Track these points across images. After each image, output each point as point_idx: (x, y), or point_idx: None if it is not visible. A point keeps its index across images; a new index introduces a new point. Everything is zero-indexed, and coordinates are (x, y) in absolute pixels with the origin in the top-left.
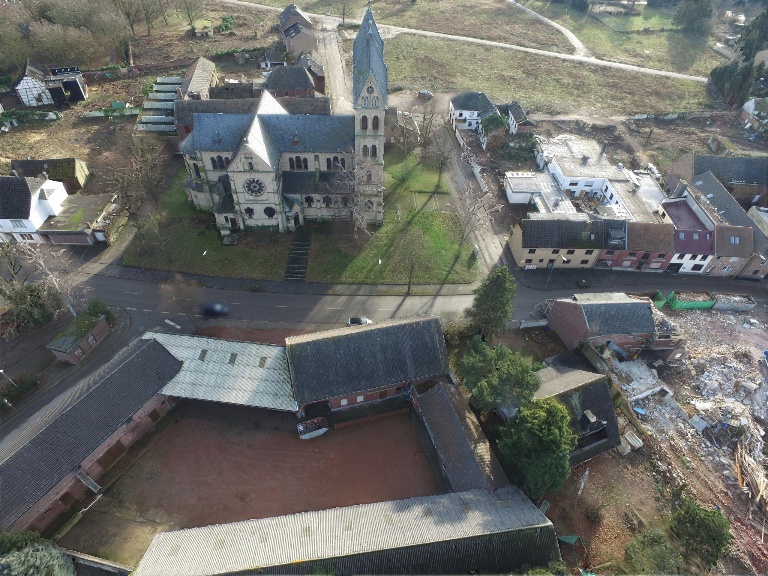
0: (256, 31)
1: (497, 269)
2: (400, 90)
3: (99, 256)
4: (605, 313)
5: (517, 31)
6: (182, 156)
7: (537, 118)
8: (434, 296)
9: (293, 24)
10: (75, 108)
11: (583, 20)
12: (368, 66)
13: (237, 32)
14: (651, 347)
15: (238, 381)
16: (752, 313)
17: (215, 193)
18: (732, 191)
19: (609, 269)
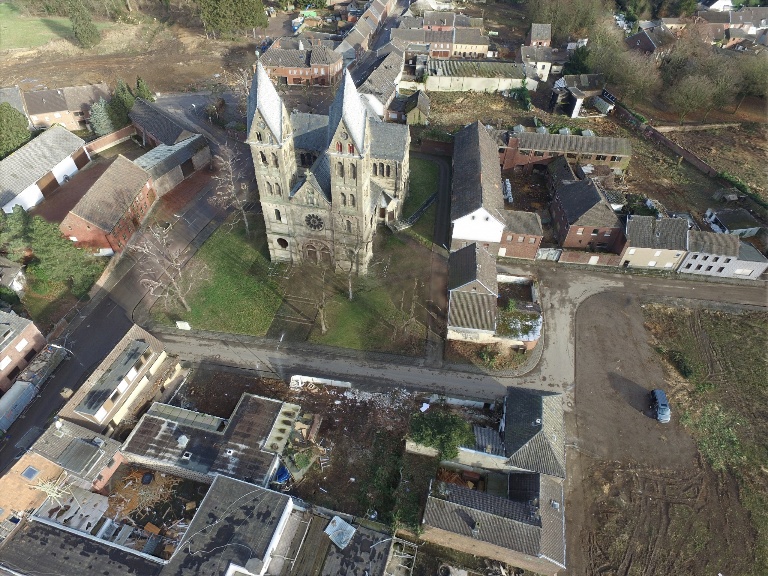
0: None
1: None
2: (681, 371)
3: None
4: None
5: None
6: (448, 161)
7: None
8: (157, 279)
9: None
10: (553, 115)
11: None
12: None
13: None
14: None
15: (142, 161)
16: None
17: None
18: None
19: None
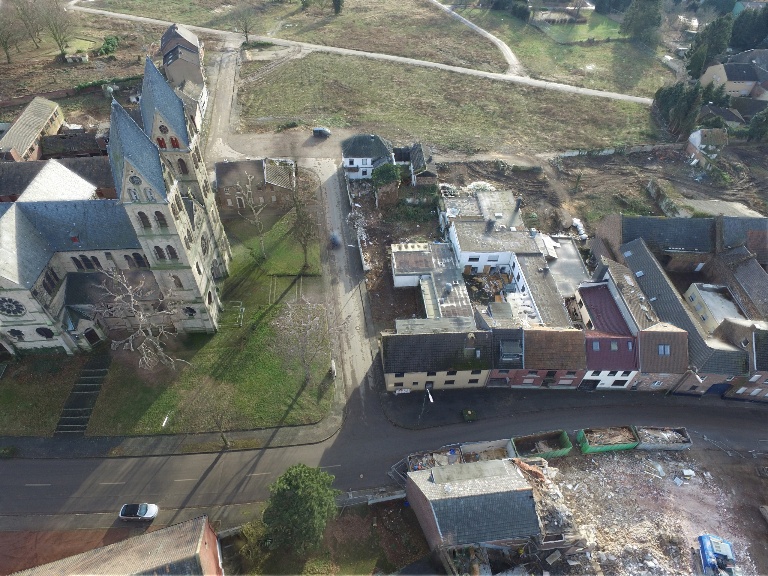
0: (139, 54)
1: (289, 470)
2: (293, 126)
3: None
4: (465, 511)
5: (447, 46)
6: None
7: (450, 159)
8: (261, 450)
9: (174, 48)
10: None
11: (523, 30)
12: (121, 150)
13: (118, 56)
14: (537, 548)
15: None
16: (688, 452)
17: None
18: (670, 259)
19: (507, 387)
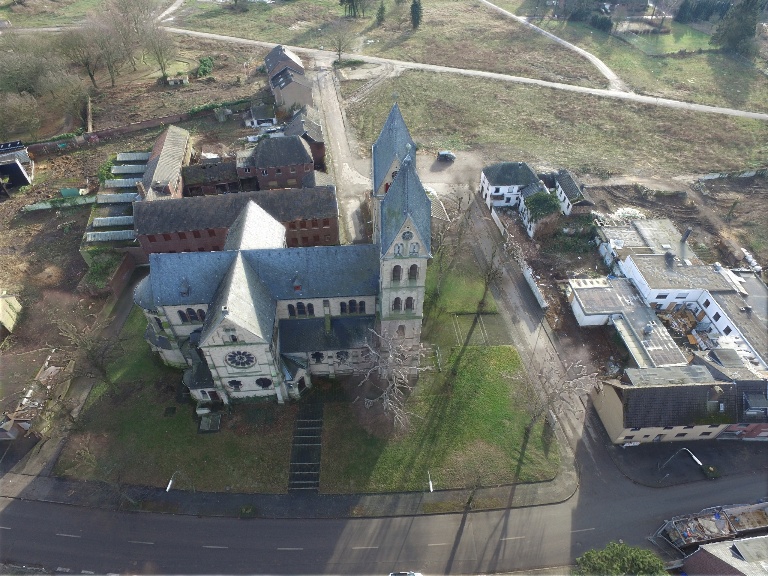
0: (239, 76)
1: (639, 559)
2: None
3: (24, 460)
4: None
5: (538, 60)
6: (147, 269)
7: (586, 184)
8: (505, 510)
9: (282, 70)
10: (16, 197)
11: (608, 42)
12: (405, 206)
13: (217, 77)
14: None
15: None
16: None
17: (186, 356)
18: None
19: (738, 439)
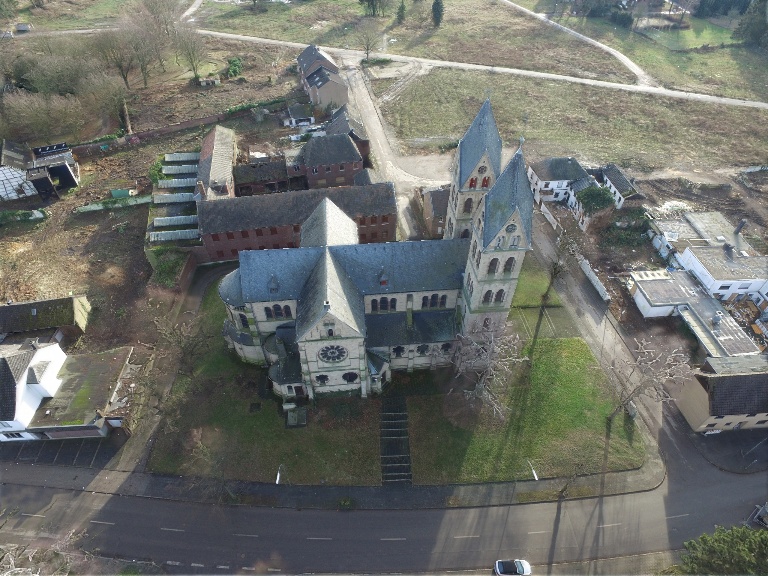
0: (270, 76)
1: None
2: (455, 147)
3: (117, 457)
4: None
5: (563, 57)
6: (209, 268)
7: None
8: (598, 498)
9: (317, 69)
10: (66, 199)
11: (630, 38)
12: (513, 199)
13: (247, 77)
14: None
15: None
16: None
17: (271, 352)
18: None
19: None
